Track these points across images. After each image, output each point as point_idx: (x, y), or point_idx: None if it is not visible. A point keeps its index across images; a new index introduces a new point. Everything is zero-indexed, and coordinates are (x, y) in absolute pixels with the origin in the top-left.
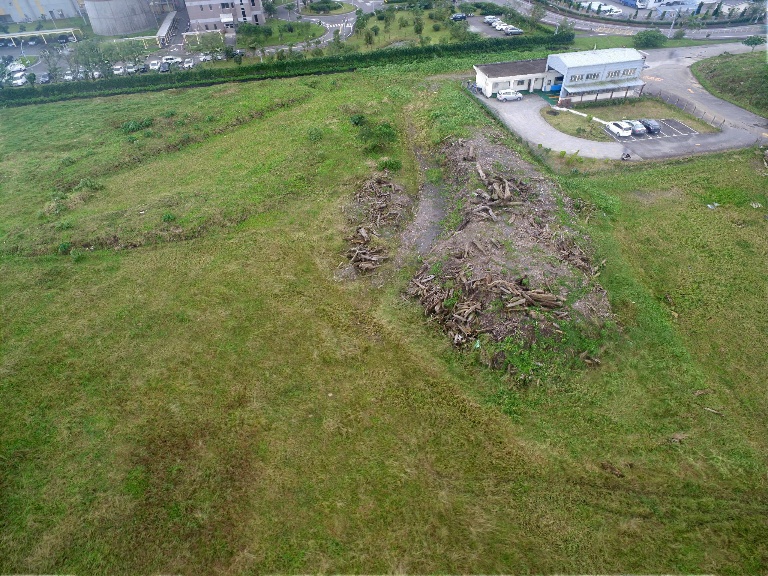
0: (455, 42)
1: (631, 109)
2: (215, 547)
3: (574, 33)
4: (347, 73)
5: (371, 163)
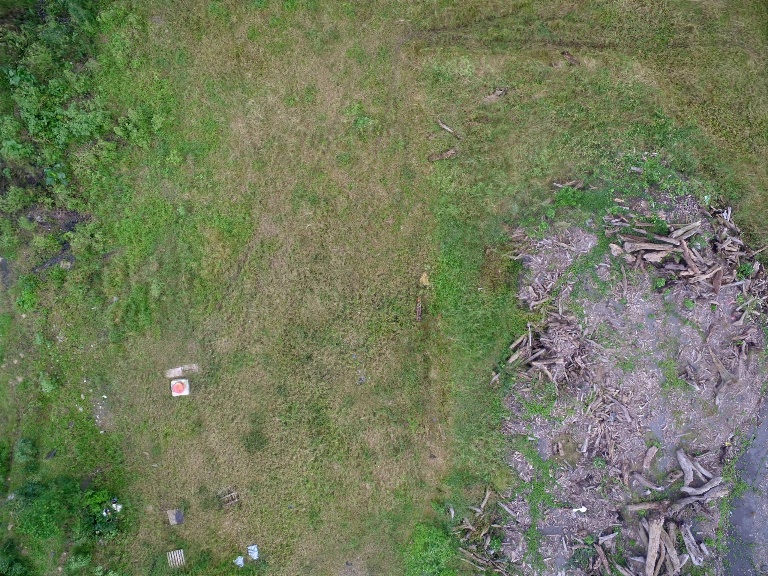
0: None
1: None
2: None
3: None
4: None
5: None
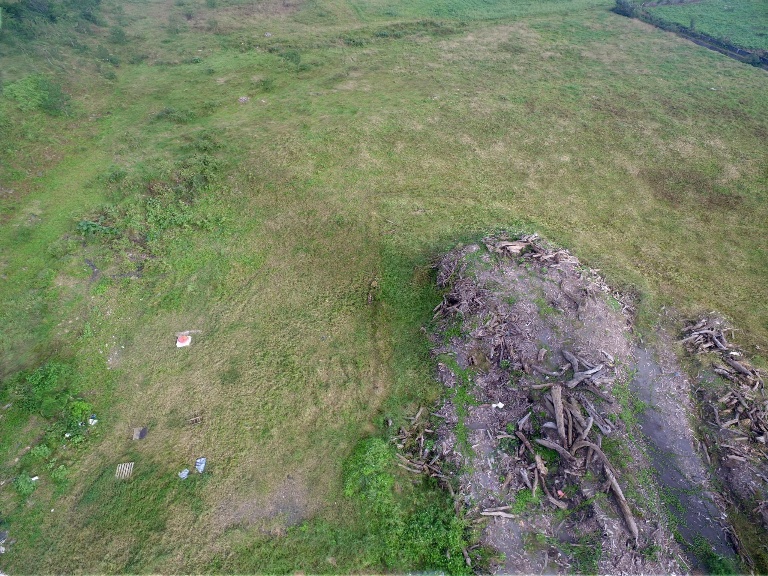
0: None
1: None
2: (652, 175)
3: None
4: None
5: None
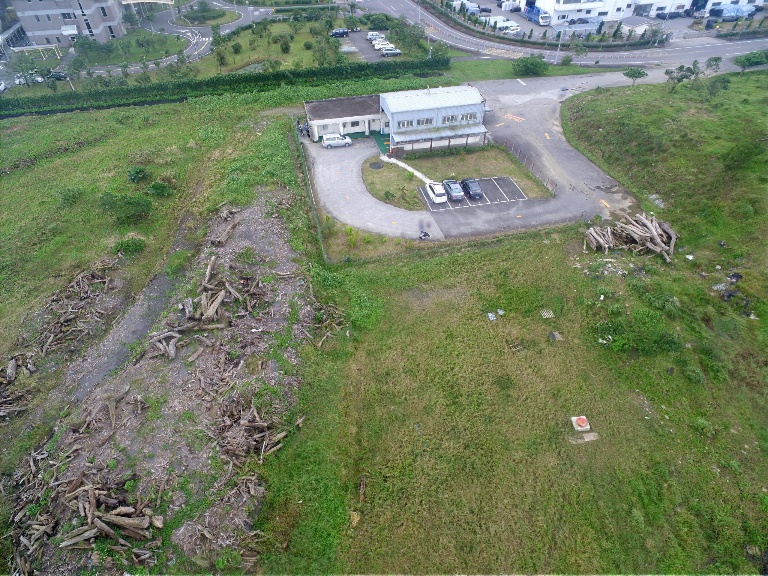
0: (310, 67)
1: (468, 161)
2: None
3: (450, 57)
4: (172, 104)
5: (114, 241)
